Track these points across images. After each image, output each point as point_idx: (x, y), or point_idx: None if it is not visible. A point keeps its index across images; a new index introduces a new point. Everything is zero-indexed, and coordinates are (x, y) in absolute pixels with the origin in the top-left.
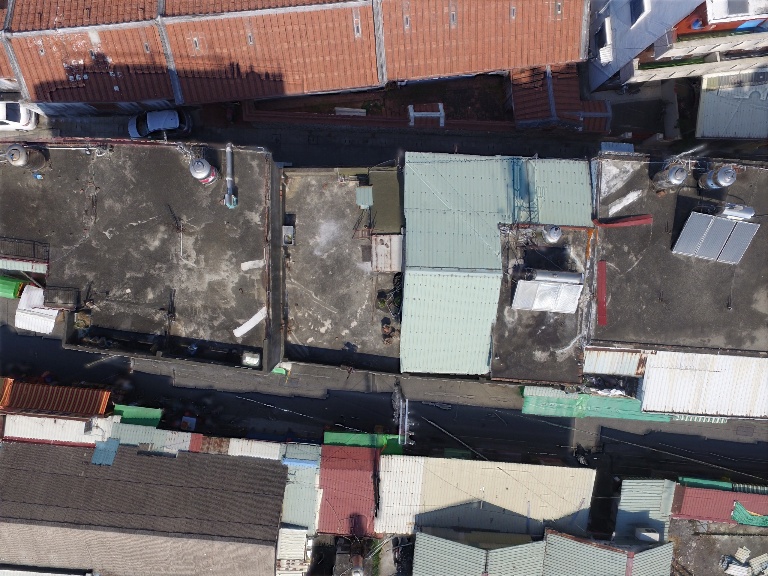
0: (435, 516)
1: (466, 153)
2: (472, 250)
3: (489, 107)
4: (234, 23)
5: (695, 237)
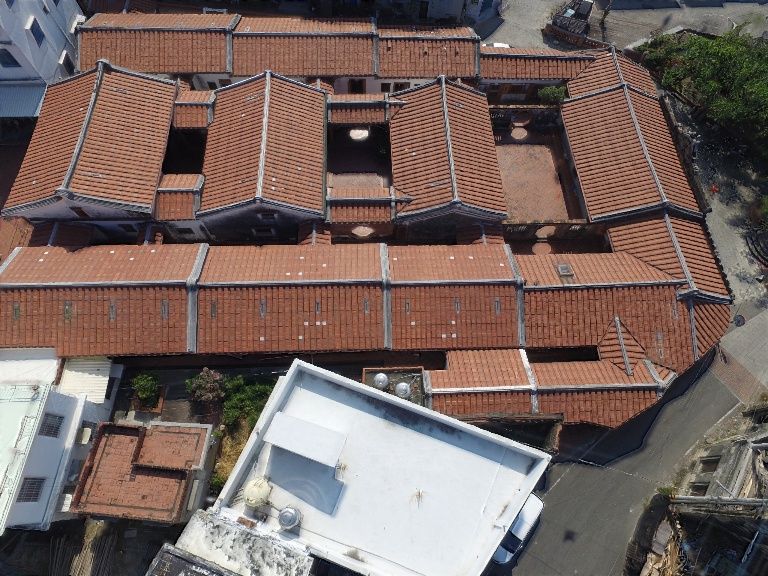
0: None
1: None
2: None
3: None
4: None
5: None
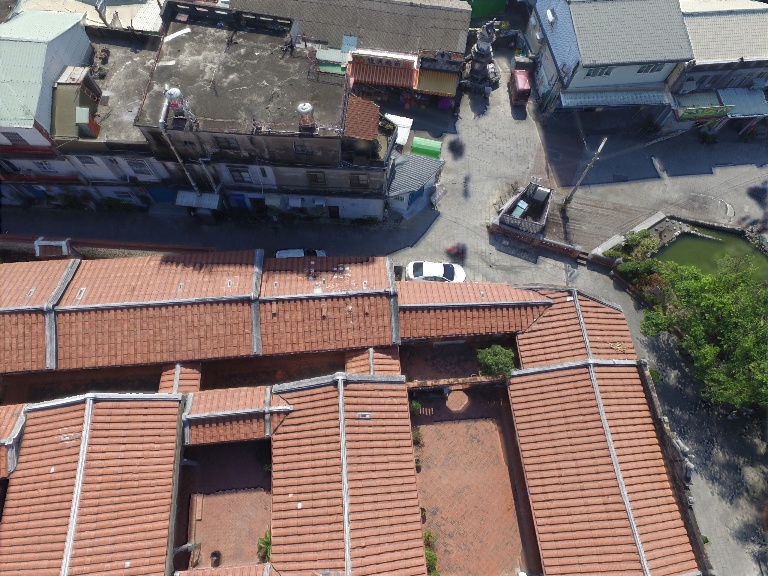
0: (132, 2)
1: None
2: None
3: None
4: (190, 296)
5: None
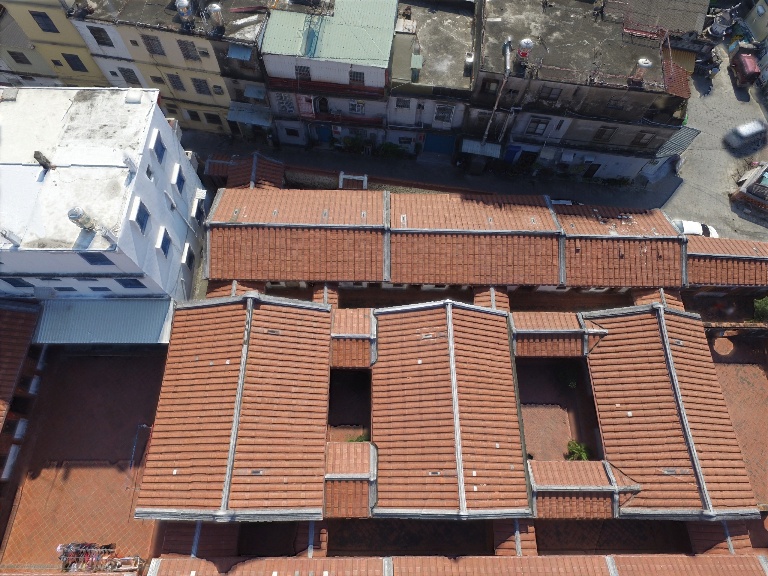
0: None
1: None
2: (354, 2)
3: None
4: (503, 228)
5: None
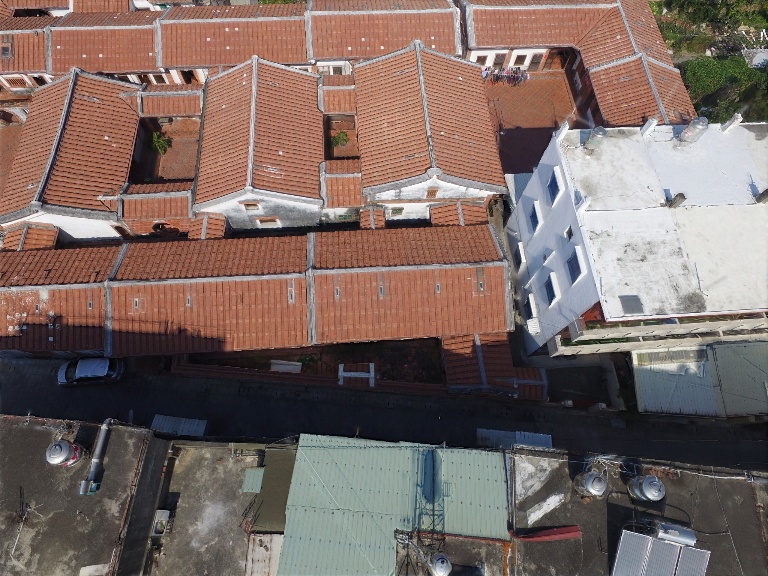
0: None
1: (401, 412)
2: (360, 567)
3: (426, 366)
4: (176, 288)
5: (635, 562)
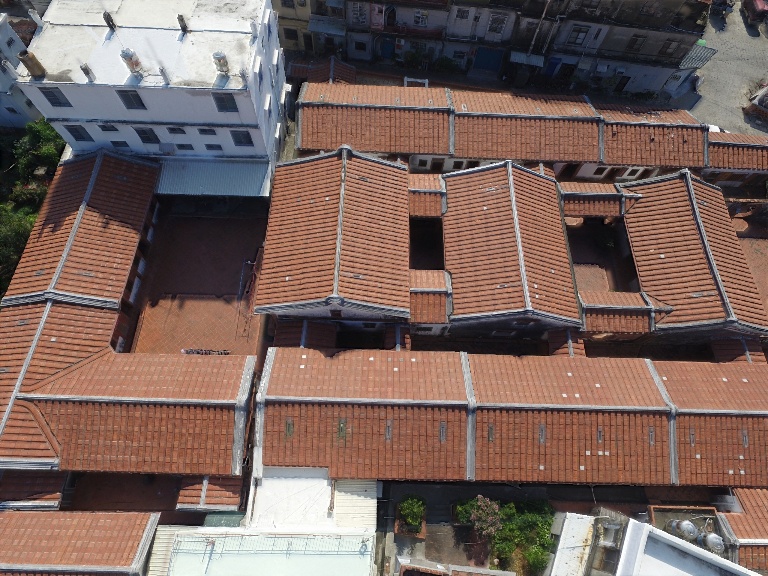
0: None
1: None
2: None
3: None
4: None
5: None
